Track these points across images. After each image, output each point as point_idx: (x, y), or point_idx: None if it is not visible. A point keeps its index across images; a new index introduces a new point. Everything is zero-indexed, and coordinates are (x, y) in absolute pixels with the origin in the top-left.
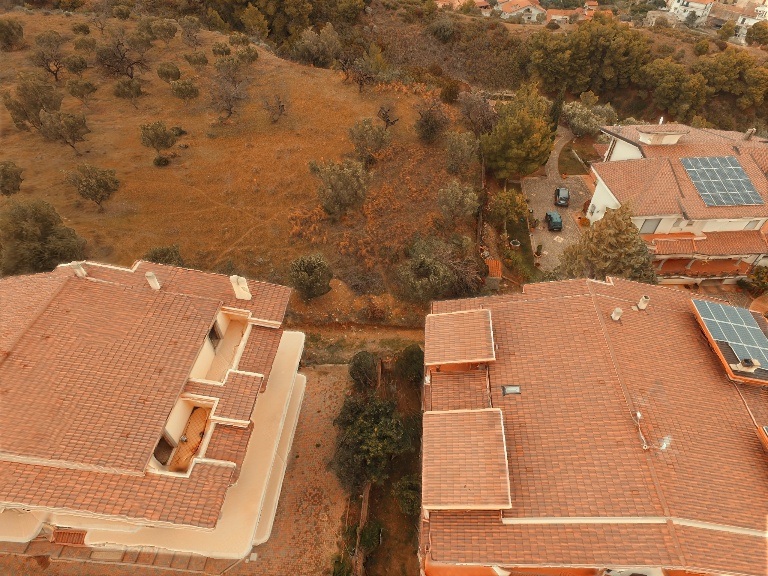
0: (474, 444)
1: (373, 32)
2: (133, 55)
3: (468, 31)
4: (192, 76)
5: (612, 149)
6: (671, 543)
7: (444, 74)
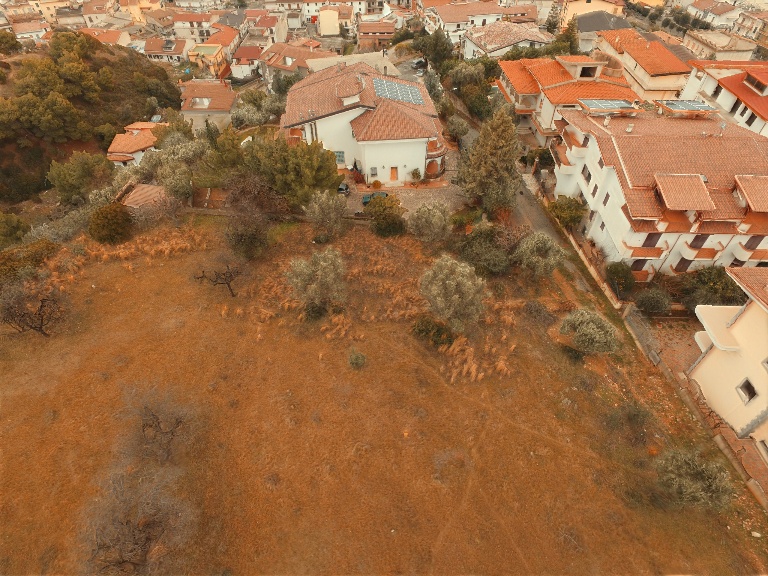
0: (763, 188)
1: None
2: None
3: None
4: None
5: (316, 132)
6: (762, 140)
7: None
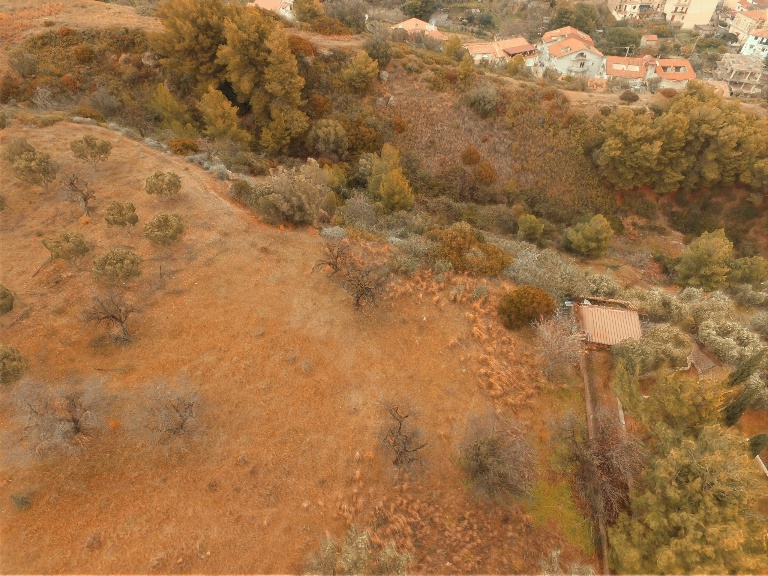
0: None
1: (389, 105)
2: None
3: (516, 102)
4: (58, 275)
5: None
6: None
7: (482, 161)
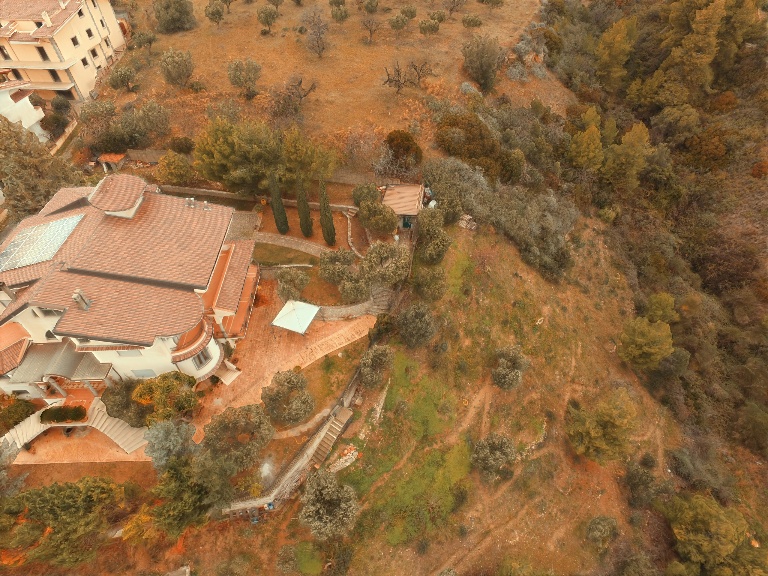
0: None
1: None
2: (439, 1)
3: None
4: None
5: None
6: None
7: None
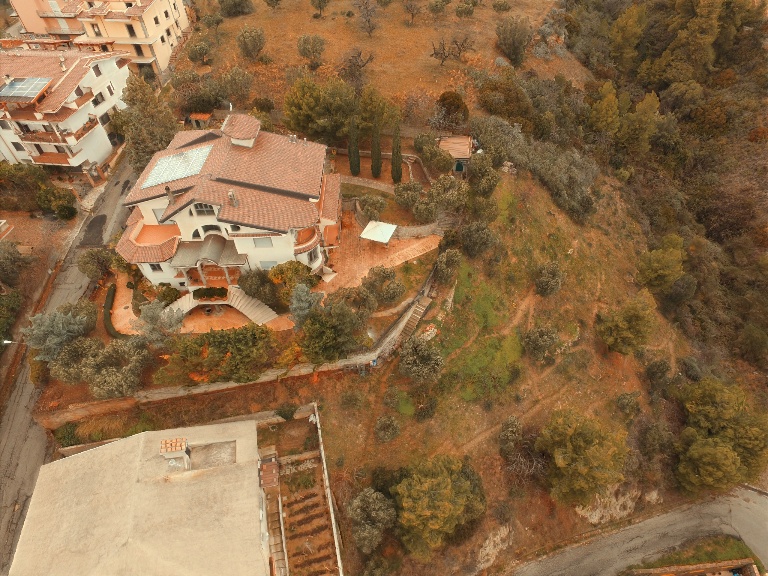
0: None
1: None
2: None
3: None
4: None
5: None
6: None
7: None
